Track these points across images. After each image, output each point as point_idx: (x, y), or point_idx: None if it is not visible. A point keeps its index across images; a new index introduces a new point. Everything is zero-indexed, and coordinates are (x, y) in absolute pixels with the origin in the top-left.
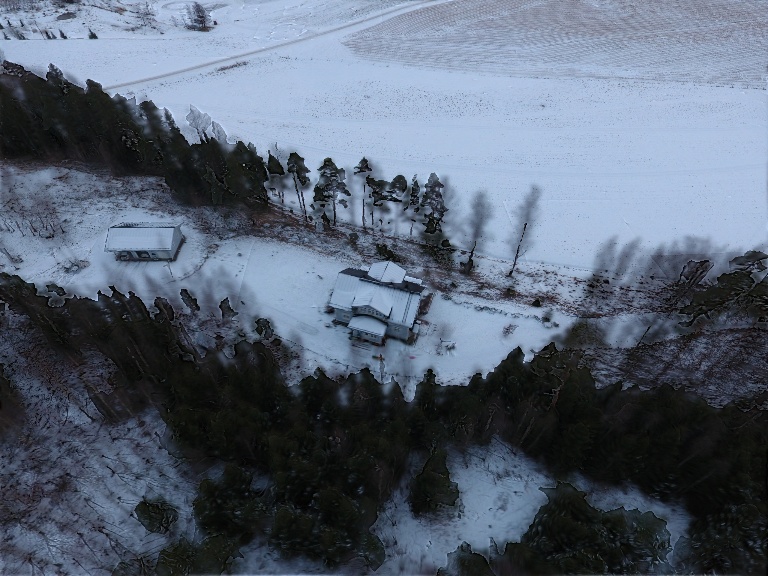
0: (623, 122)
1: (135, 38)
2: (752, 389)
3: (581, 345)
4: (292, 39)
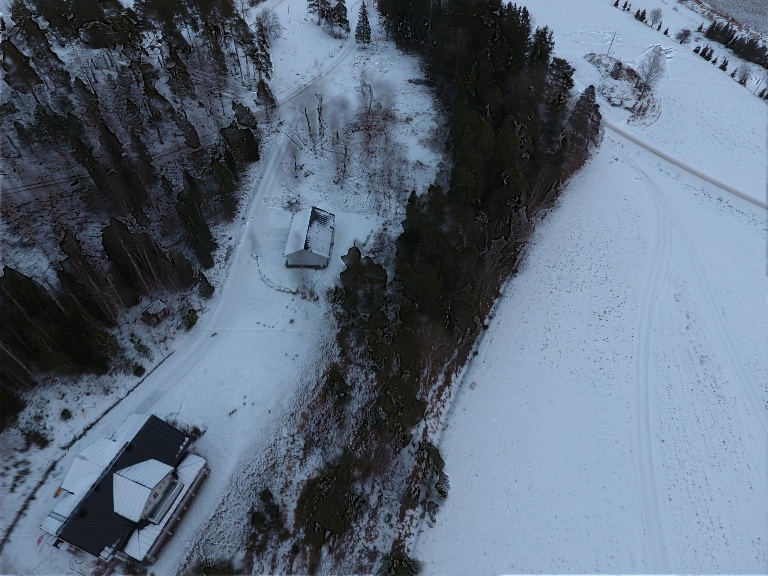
0: None
1: None
2: None
3: None
4: None
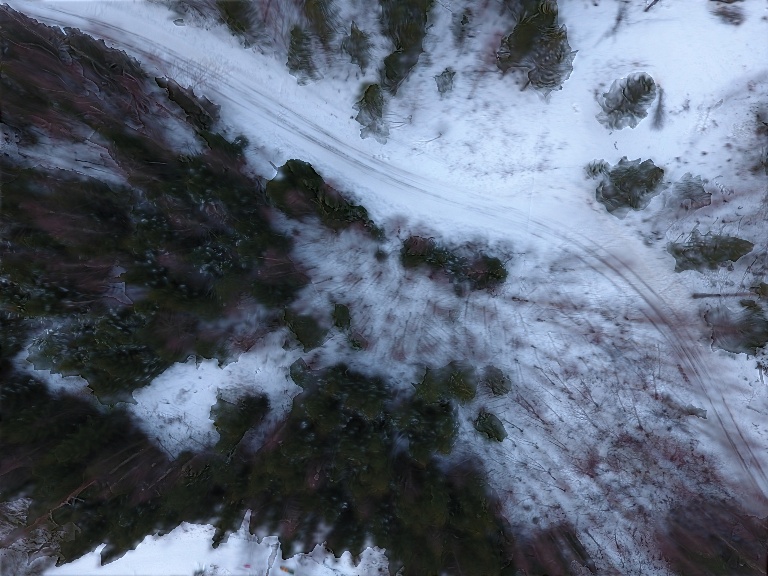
0: None
1: None
2: None
3: (41, 558)
4: None
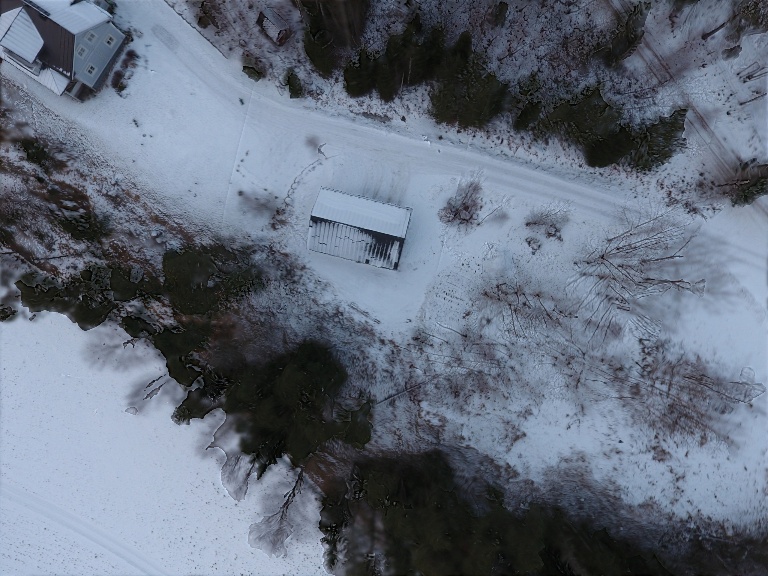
0: None
1: None
2: None
3: None
4: None
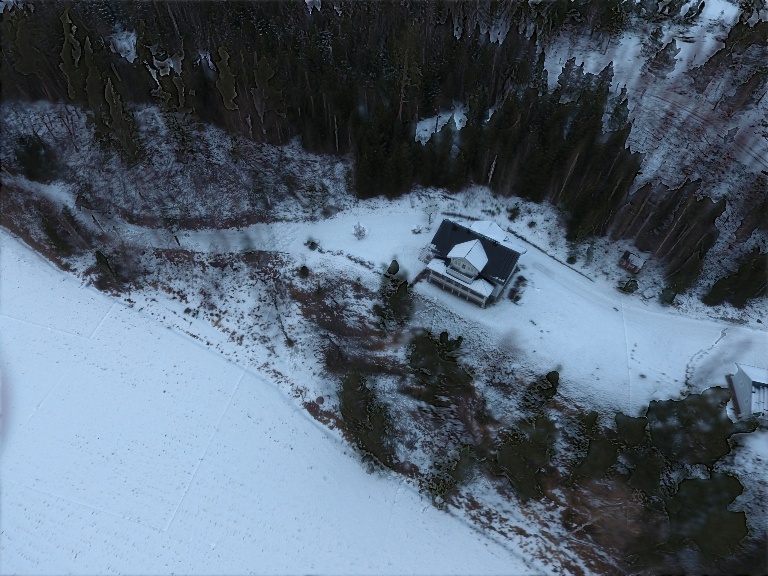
0: None
1: None
2: (225, 160)
3: (300, 226)
4: None
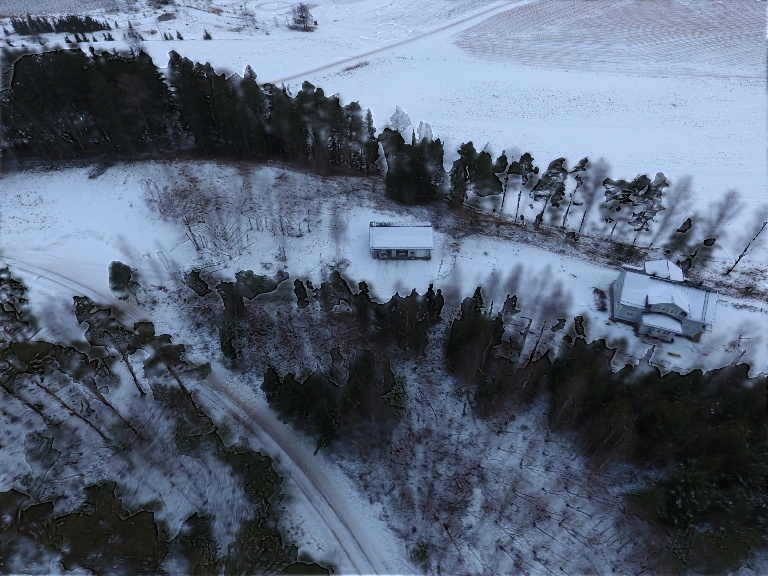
0: (763, 121)
1: (247, 39)
2: None
3: None
4: (402, 39)
